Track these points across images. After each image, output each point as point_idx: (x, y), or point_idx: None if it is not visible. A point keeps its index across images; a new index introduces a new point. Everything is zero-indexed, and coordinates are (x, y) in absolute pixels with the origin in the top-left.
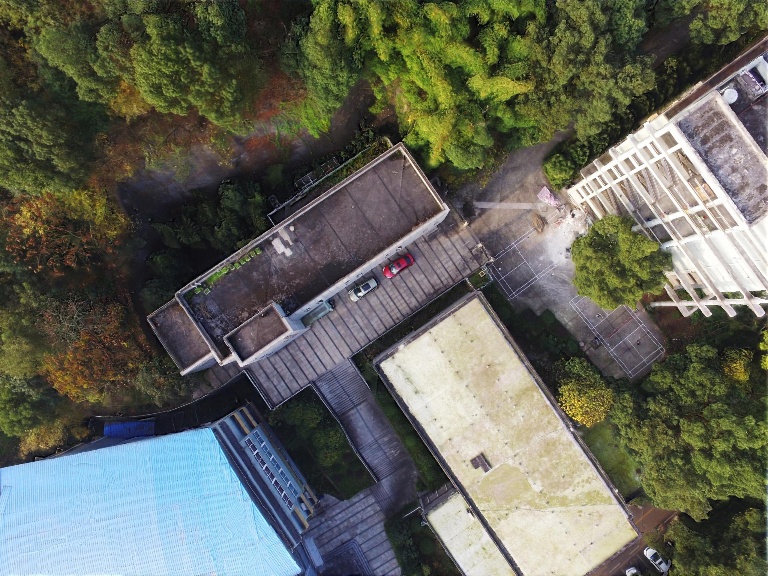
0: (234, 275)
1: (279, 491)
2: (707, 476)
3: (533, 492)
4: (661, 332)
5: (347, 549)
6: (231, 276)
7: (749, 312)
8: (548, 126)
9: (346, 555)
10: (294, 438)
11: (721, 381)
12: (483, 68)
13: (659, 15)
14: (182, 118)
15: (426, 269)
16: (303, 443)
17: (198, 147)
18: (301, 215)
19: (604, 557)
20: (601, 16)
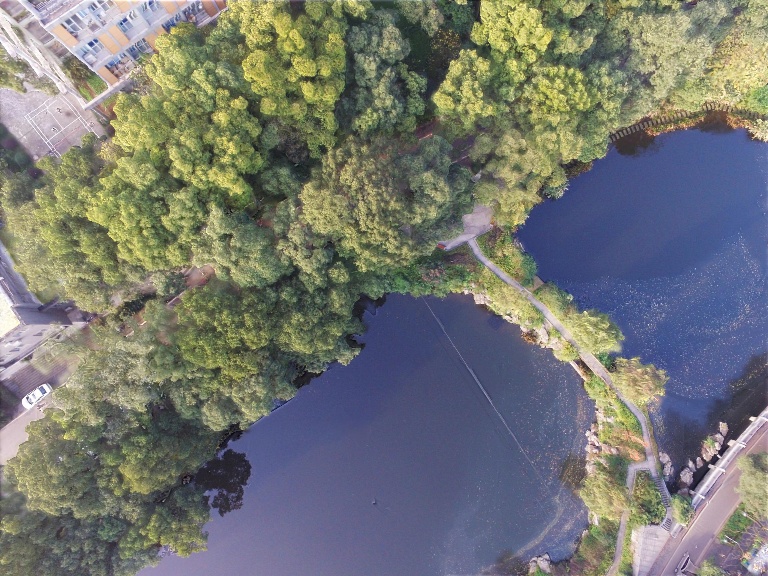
0: None
1: None
2: None
3: None
4: None
5: None
6: None
7: None
8: None
9: None
10: None
11: (87, 161)
12: None
13: None
14: None
15: None
16: None
17: None
18: None
19: None
20: None
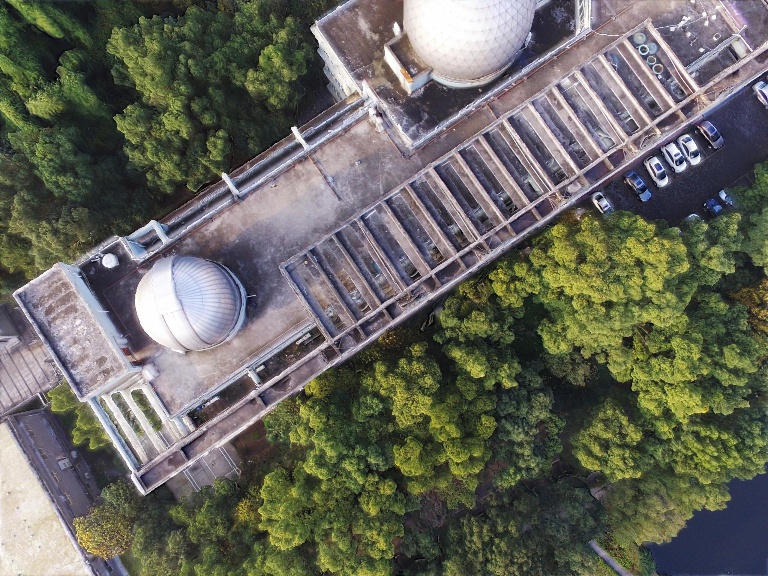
0: None
1: None
2: None
3: None
4: (236, 453)
5: None
6: None
7: None
8: None
9: None
10: None
11: (224, 521)
12: None
13: (128, 162)
14: None
15: (6, 381)
16: None
17: None
18: None
19: None
20: (0, 177)
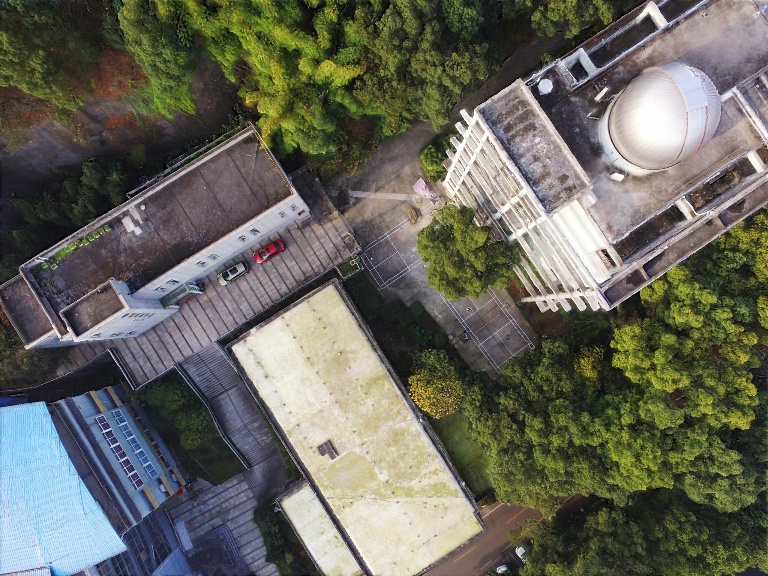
0: (82, 251)
1: (127, 470)
2: (545, 472)
3: (379, 481)
4: (531, 328)
5: (217, 534)
6: (79, 252)
7: (611, 310)
8: (391, 113)
9: (216, 540)
10: (159, 419)
11: (568, 377)
12: (318, 52)
13: (503, 6)
14: (6, 89)
15: (298, 256)
16: (171, 425)
17: (48, 122)
18: (152, 194)
19: (448, 550)
20: (423, 2)
